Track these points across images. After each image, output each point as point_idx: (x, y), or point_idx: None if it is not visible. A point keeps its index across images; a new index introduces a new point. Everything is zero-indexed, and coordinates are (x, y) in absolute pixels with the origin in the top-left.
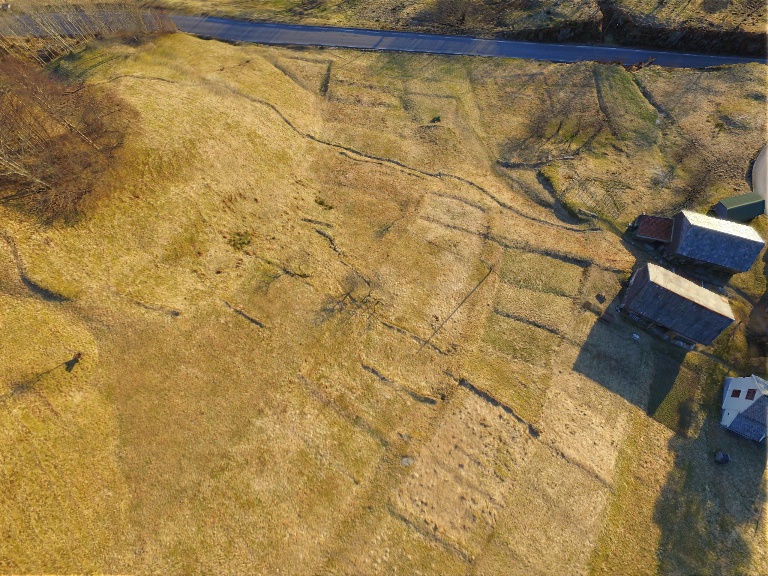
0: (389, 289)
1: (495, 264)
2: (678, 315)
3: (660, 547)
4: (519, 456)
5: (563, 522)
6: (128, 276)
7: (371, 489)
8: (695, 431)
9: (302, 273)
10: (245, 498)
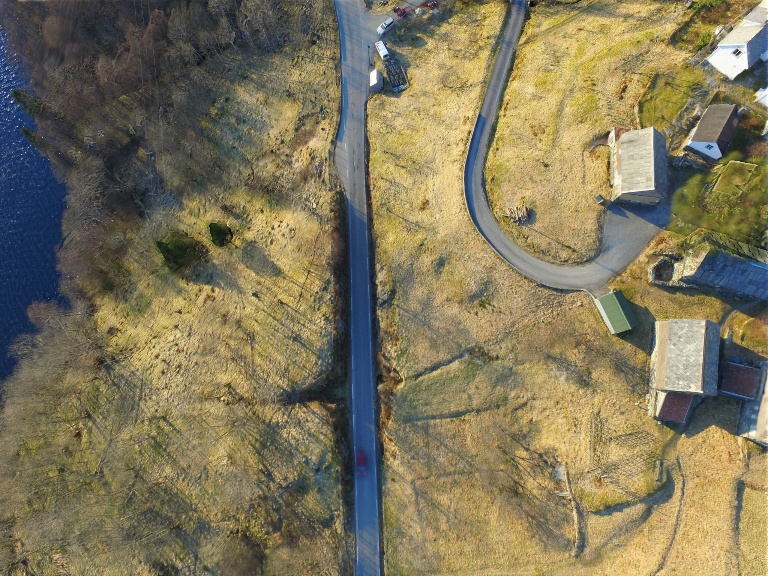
0: None
1: None
2: None
3: None
4: None
5: None
6: None
7: None
8: None
9: None
10: None
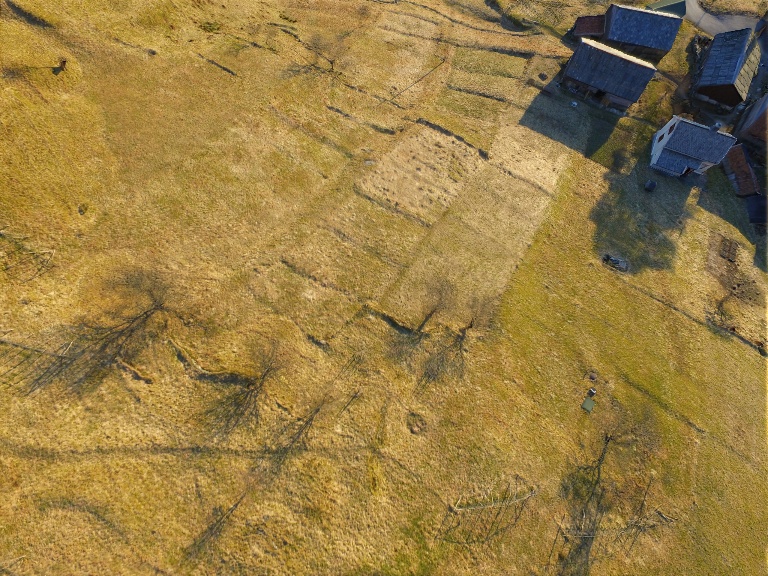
0: (351, 68)
1: (448, 57)
2: (609, 75)
3: (596, 235)
4: (470, 169)
5: (510, 211)
6: (106, 22)
7: (338, 180)
8: (627, 170)
9: (269, 47)
10: (224, 175)
